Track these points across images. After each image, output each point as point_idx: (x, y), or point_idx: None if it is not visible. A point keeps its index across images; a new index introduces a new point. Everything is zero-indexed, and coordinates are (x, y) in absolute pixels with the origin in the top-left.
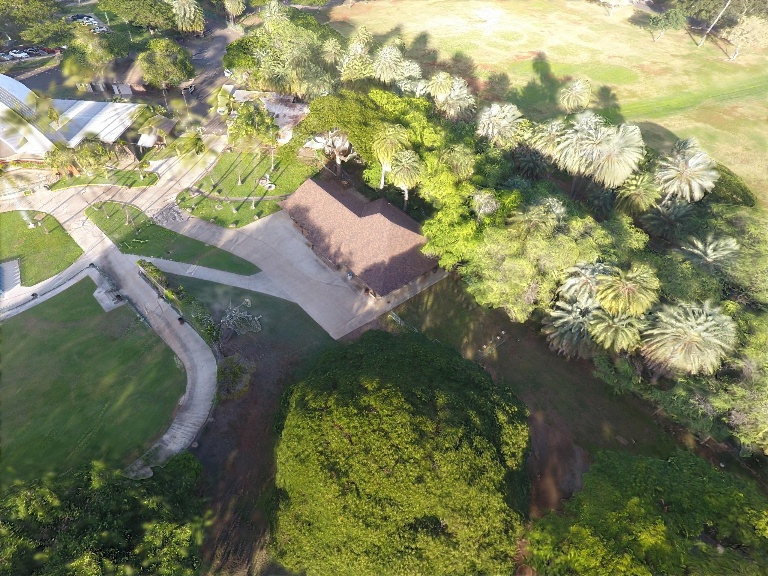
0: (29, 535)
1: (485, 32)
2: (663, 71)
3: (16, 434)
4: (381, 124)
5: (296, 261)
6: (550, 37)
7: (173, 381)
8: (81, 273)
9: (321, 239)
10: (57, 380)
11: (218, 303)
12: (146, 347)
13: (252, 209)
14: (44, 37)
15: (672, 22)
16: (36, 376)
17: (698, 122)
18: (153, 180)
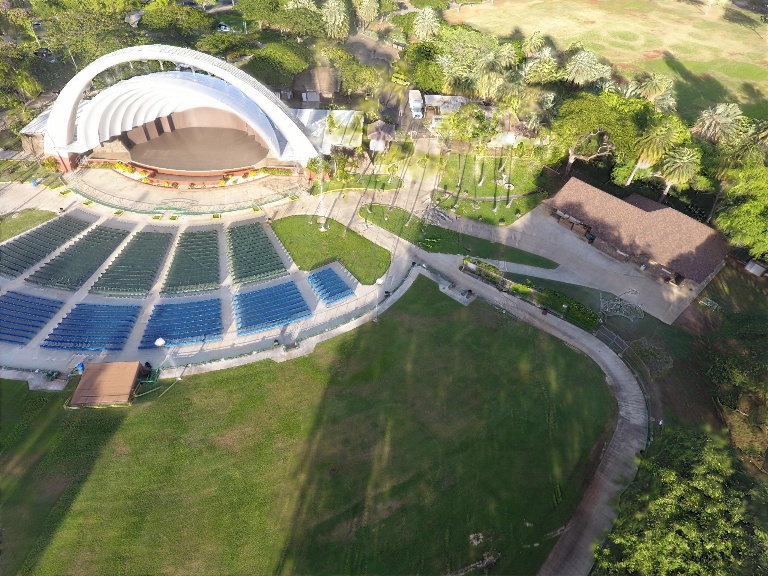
0: (730, 487)
1: (601, 33)
2: None
3: (484, 416)
4: (632, 124)
5: (582, 255)
6: (664, 36)
7: (585, 365)
8: (412, 271)
9: (609, 233)
10: (478, 368)
11: None
12: (531, 336)
13: (508, 208)
14: (221, 48)
15: None
16: (455, 365)
17: None
18: (399, 183)
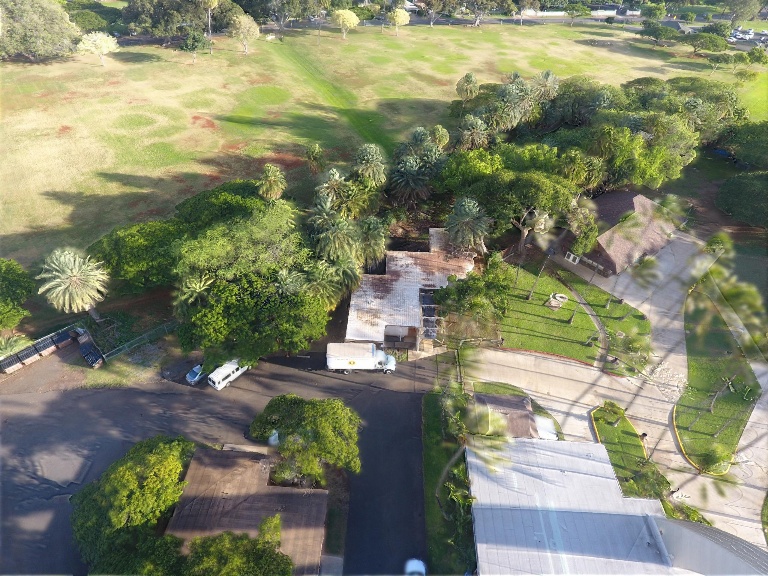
0: None
1: (114, 132)
2: (265, 77)
3: None
4: None
5: (662, 273)
6: (154, 102)
7: None
8: None
9: (652, 244)
10: None
11: (760, 302)
12: None
13: (609, 307)
14: None
15: (205, 42)
16: None
17: (364, 87)
18: None
